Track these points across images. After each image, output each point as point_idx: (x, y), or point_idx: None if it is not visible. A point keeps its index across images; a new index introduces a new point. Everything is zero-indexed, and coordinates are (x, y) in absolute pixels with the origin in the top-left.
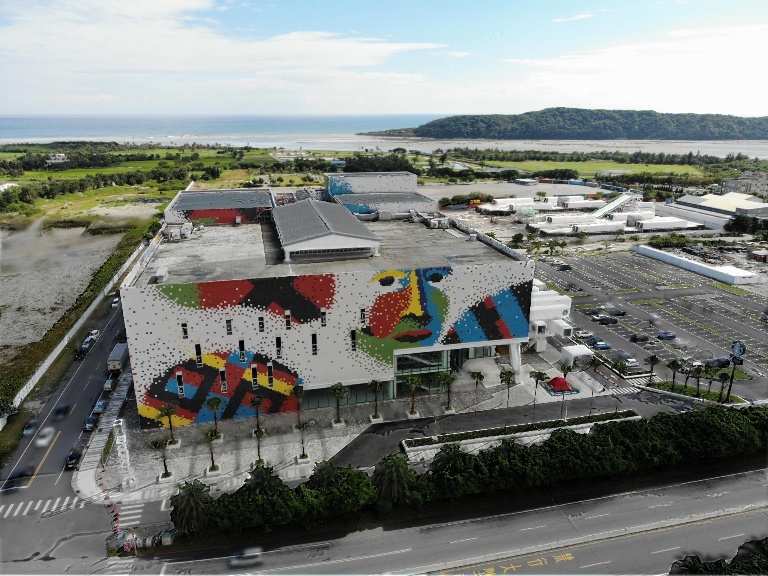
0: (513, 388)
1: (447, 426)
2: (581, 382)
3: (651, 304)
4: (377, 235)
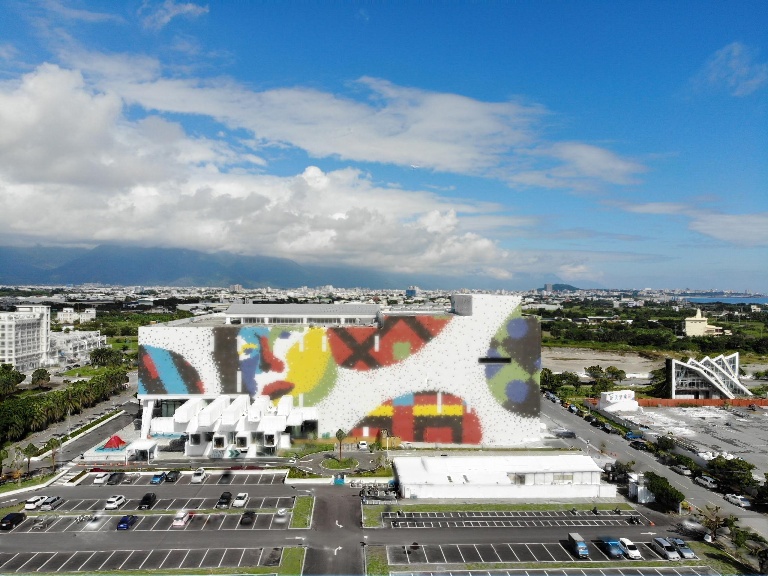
0: (138, 435)
1: (124, 419)
2: (109, 455)
3: (271, 564)
4: (294, 325)
